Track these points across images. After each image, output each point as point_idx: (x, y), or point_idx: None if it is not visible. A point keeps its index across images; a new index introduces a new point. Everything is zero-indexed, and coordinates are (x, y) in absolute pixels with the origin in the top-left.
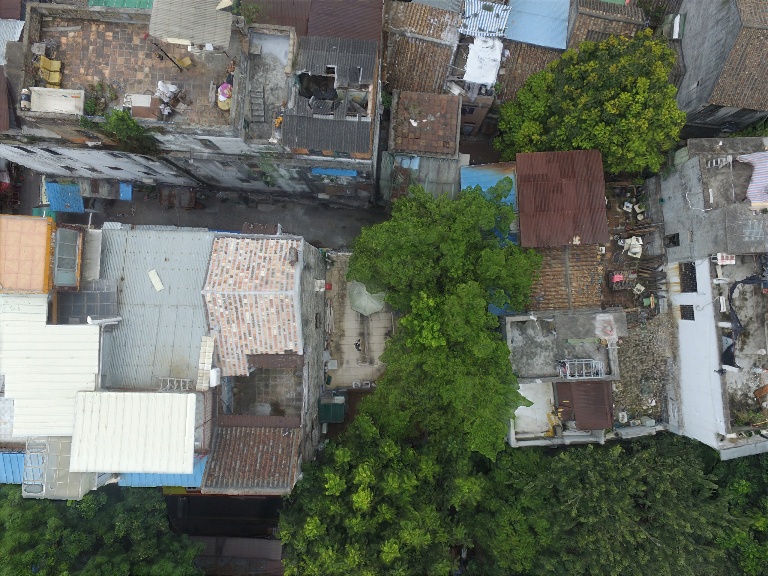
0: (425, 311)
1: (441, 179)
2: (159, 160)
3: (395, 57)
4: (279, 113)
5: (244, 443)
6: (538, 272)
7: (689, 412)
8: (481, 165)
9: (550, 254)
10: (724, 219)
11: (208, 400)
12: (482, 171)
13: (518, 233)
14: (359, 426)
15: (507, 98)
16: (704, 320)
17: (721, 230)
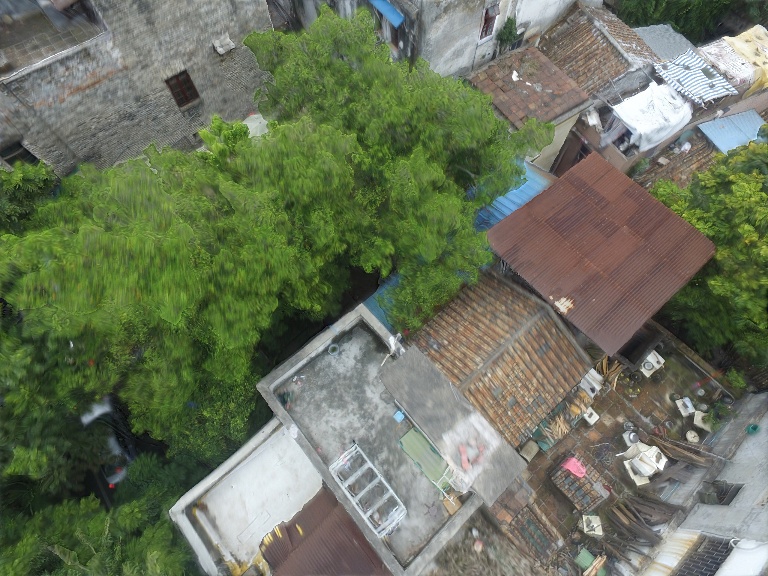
0: None
1: None
2: None
3: (563, 38)
4: None
5: None
6: (470, 312)
7: None
8: None
9: (510, 304)
10: None
11: None
12: (535, 174)
13: None
14: None
15: None
16: None
17: None
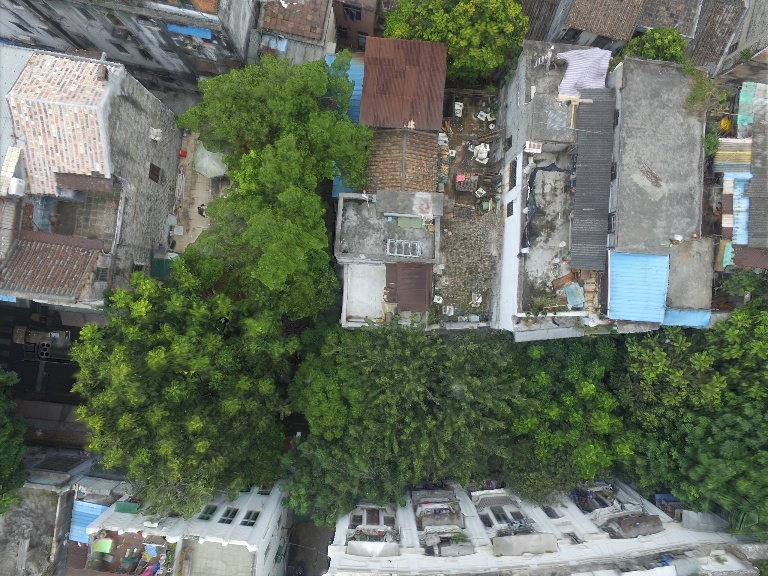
0: (249, 165)
1: None
2: (20, 1)
3: None
4: None
5: (41, 256)
6: (379, 157)
7: (503, 304)
8: None
9: (391, 140)
10: (533, 107)
11: (8, 209)
12: None
13: None
14: (173, 268)
15: (393, 7)
16: (517, 211)
17: (531, 118)
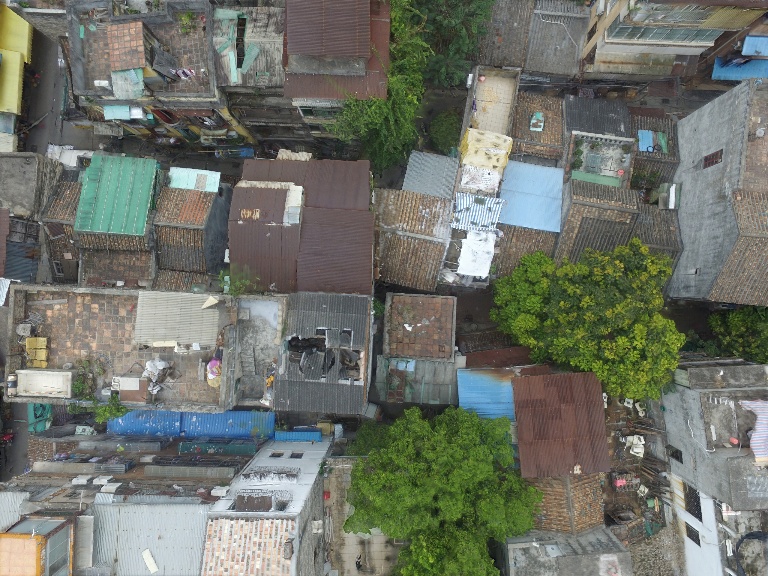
0: (425, 563)
1: (438, 381)
2: None
3: (387, 251)
4: (270, 371)
5: None
6: (539, 490)
7: None
8: (478, 370)
9: None
10: (728, 474)
11: None
12: (479, 376)
13: None
14: None
15: (502, 273)
16: (710, 555)
17: (725, 482)
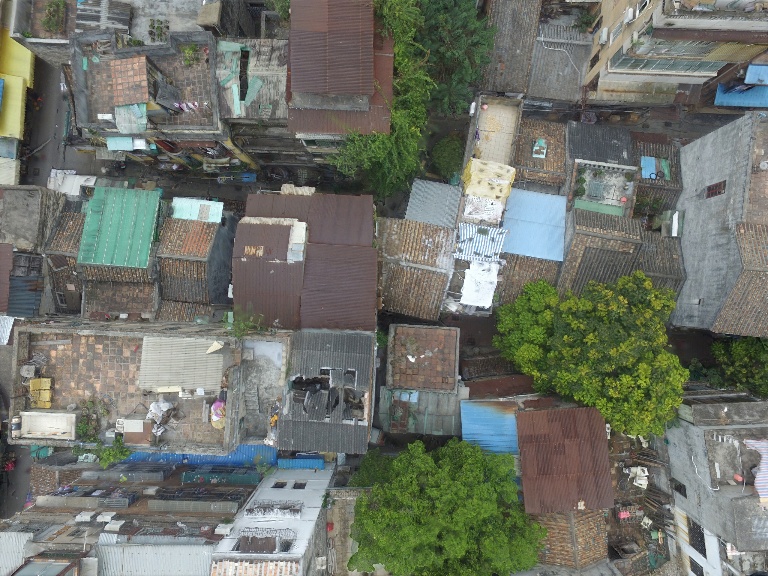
0: None
1: (441, 412)
2: None
3: (390, 281)
4: (274, 410)
5: None
6: (543, 524)
7: None
8: (481, 401)
9: None
10: (732, 514)
11: None
12: (482, 408)
13: (521, 477)
14: None
15: (505, 300)
16: None
17: (730, 522)
